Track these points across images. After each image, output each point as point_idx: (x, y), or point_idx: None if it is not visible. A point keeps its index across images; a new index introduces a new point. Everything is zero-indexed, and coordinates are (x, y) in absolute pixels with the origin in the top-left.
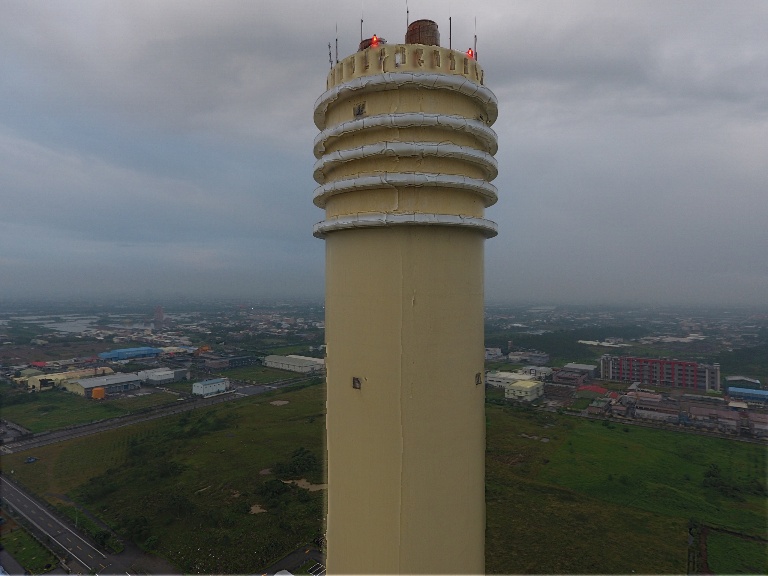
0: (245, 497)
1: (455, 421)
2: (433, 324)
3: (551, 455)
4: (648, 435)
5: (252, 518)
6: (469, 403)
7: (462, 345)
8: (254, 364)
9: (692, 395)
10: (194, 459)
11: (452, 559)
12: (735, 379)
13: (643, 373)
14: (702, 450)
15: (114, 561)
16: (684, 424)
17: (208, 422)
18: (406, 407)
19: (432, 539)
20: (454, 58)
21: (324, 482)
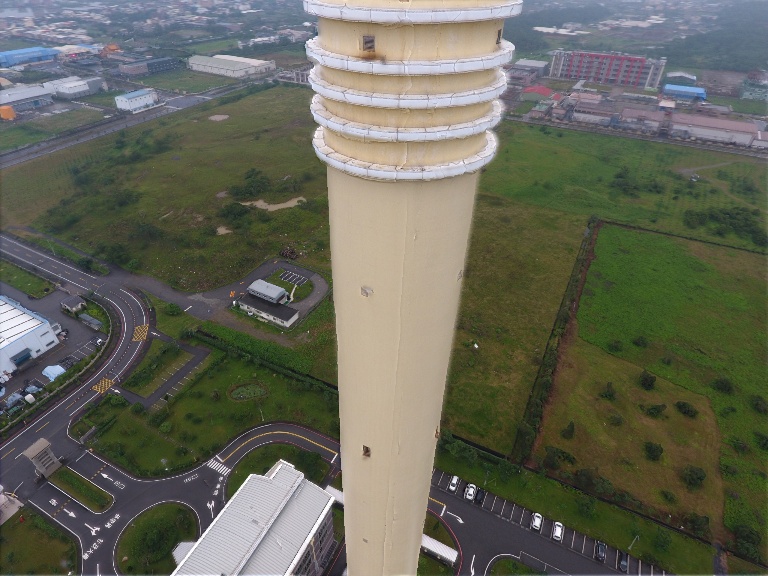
0: (209, 220)
1: (439, 309)
2: (430, 252)
3: (488, 164)
4: (578, 139)
5: (220, 239)
6: (451, 295)
7: (451, 259)
8: (178, 67)
9: (630, 94)
10: (147, 185)
11: (429, 382)
12: (675, 75)
13: (591, 70)
14: (620, 153)
15: (106, 281)
16: (613, 126)
17: (148, 144)
18: (404, 309)
19: (417, 375)
20: None
21: (281, 202)
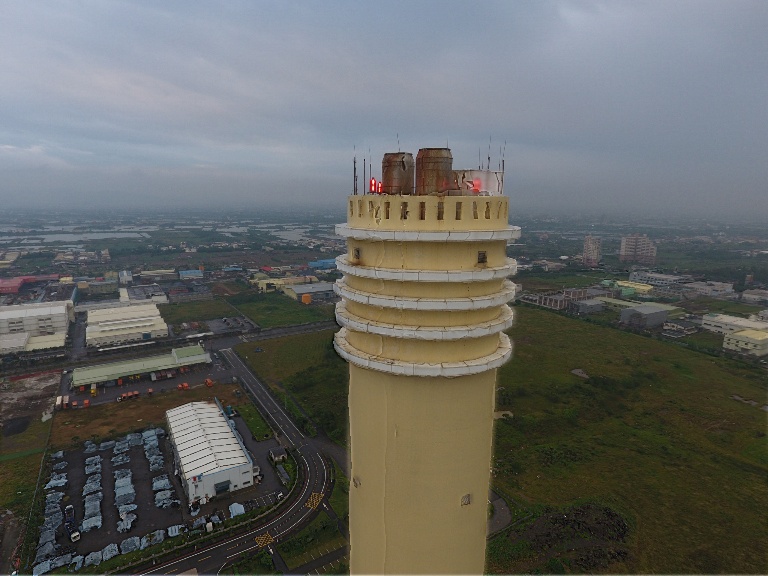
0: None
1: (435, 534)
2: (414, 455)
3: None
4: None
5: None
6: (451, 522)
7: (445, 473)
8: None
9: None
10: None
11: None
12: None
13: None
14: None
15: (309, 442)
16: None
17: None
18: (389, 516)
19: None
20: (443, 206)
21: None
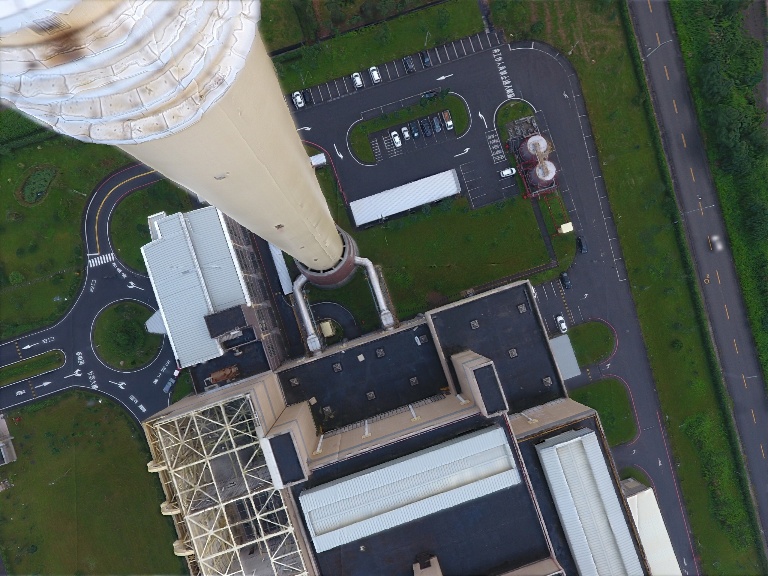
0: None
1: None
2: (256, 106)
3: None
4: None
5: None
6: (281, 99)
7: (269, 82)
8: None
9: None
10: None
11: None
12: None
13: None
14: None
15: None
16: None
17: None
18: None
19: None
20: None
21: None
